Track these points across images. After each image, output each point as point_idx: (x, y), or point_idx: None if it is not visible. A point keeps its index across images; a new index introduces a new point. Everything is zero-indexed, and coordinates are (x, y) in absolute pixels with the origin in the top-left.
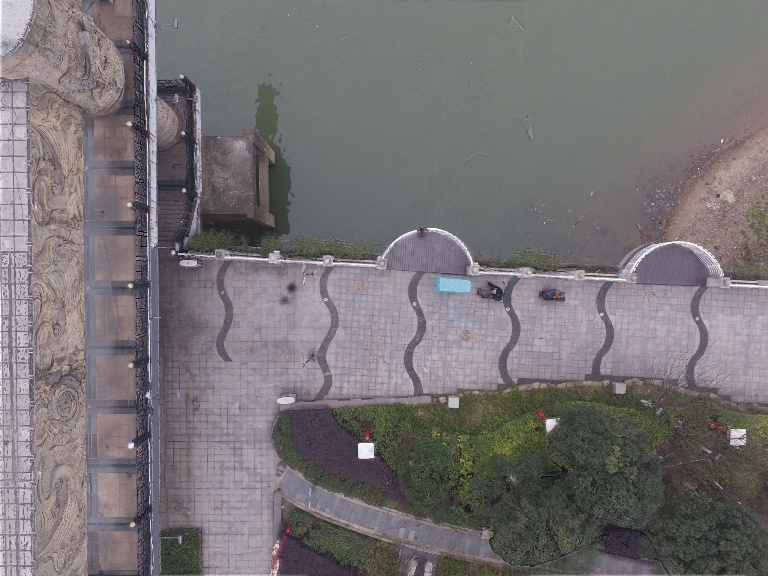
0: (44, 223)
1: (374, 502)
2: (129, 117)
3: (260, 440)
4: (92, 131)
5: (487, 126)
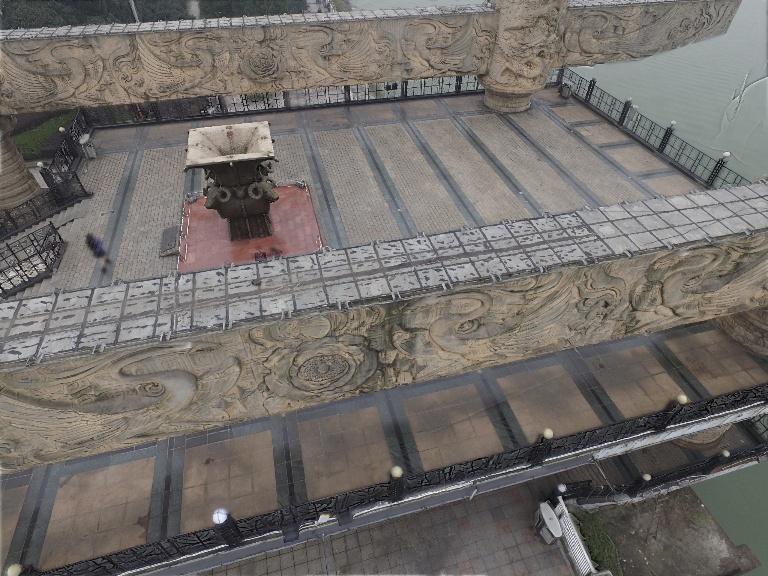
0: (648, 274)
1: None
2: (760, 371)
3: None
4: (698, 331)
5: None
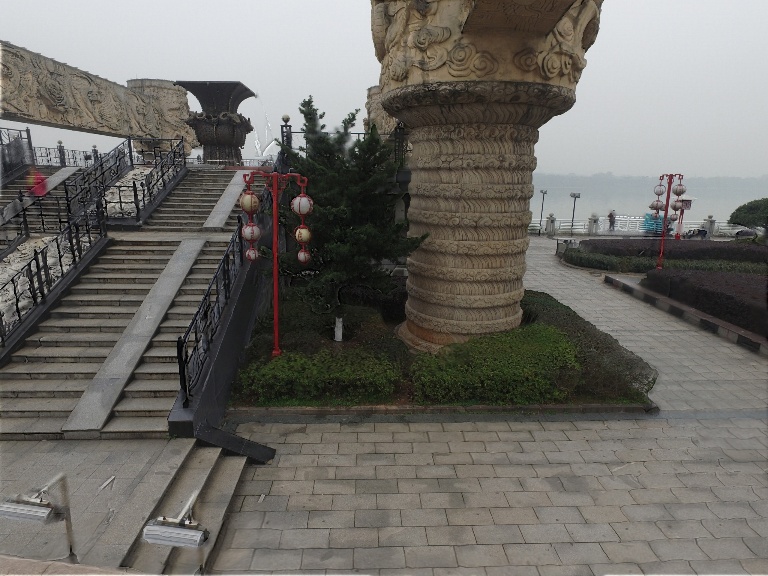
0: None
1: (750, 265)
2: None
3: (553, 266)
4: None
5: (617, 182)
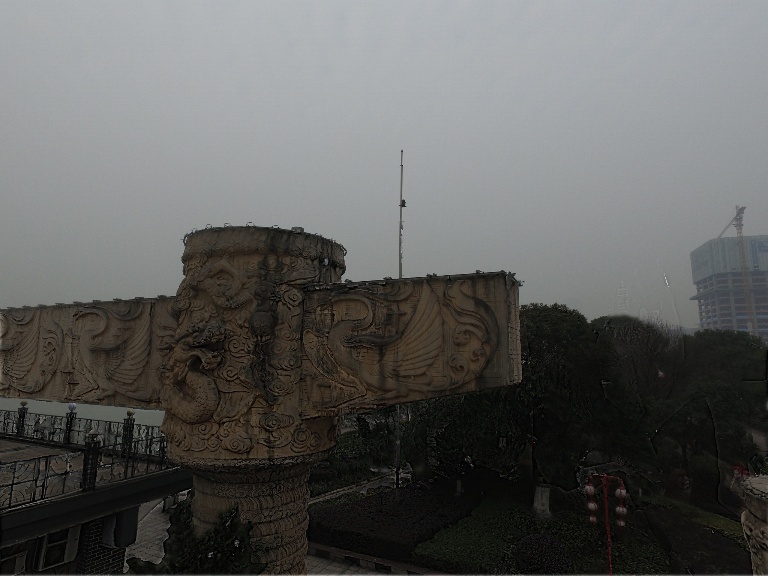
0: None
1: (319, 487)
2: None
3: None
4: None
5: None
